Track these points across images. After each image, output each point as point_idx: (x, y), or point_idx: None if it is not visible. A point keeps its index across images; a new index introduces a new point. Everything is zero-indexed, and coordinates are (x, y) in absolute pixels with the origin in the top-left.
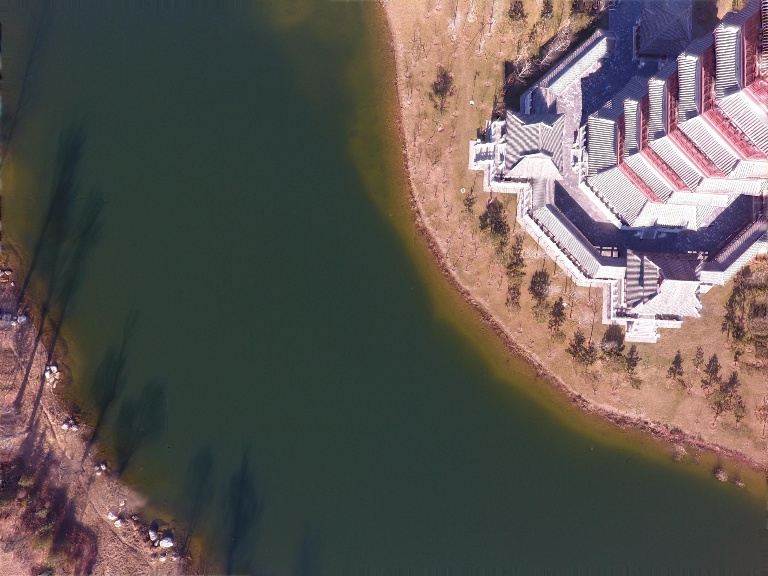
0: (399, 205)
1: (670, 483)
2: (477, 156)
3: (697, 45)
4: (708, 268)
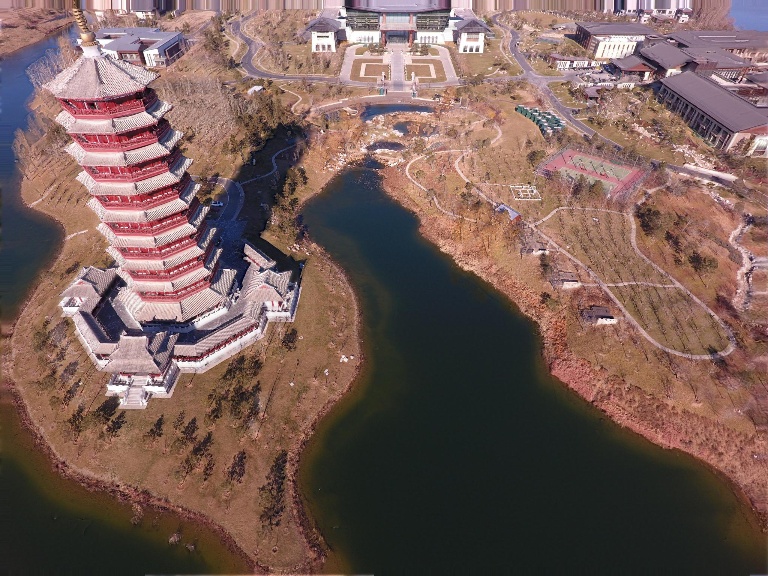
0: (2, 332)
1: (124, 557)
2: None
3: None
4: (185, 344)
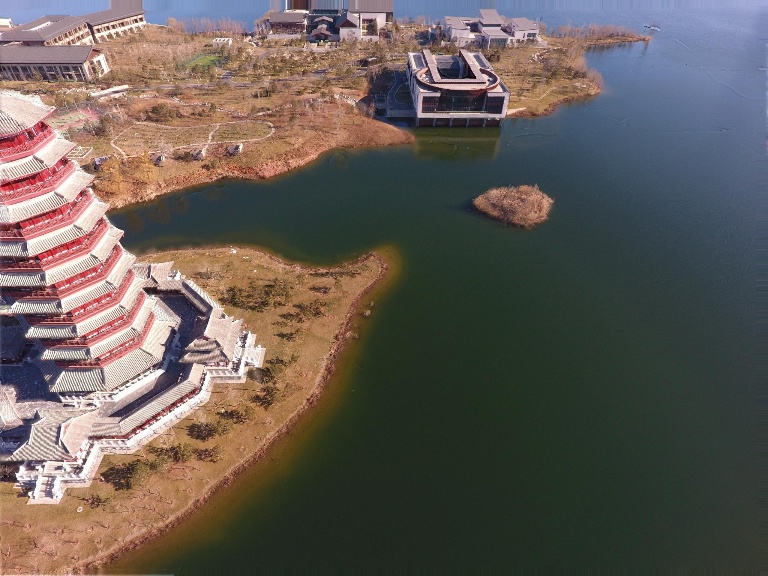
0: None
1: None
2: (47, 495)
3: (7, 303)
4: None
